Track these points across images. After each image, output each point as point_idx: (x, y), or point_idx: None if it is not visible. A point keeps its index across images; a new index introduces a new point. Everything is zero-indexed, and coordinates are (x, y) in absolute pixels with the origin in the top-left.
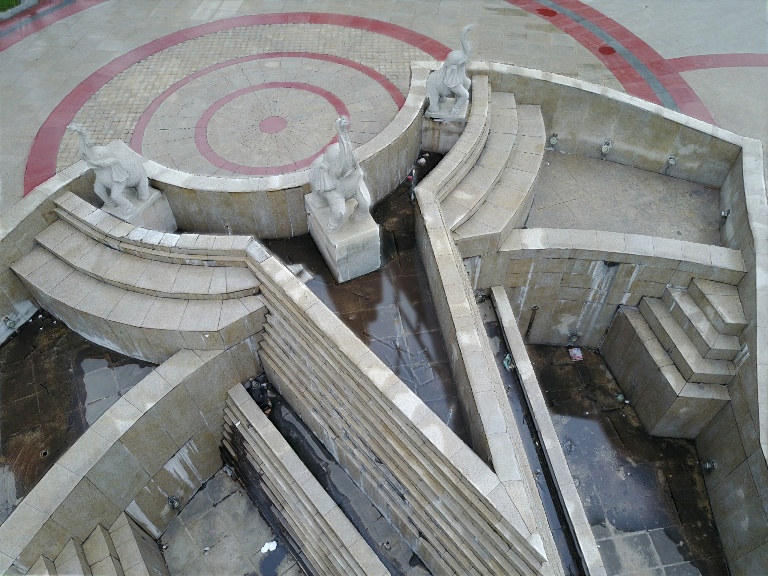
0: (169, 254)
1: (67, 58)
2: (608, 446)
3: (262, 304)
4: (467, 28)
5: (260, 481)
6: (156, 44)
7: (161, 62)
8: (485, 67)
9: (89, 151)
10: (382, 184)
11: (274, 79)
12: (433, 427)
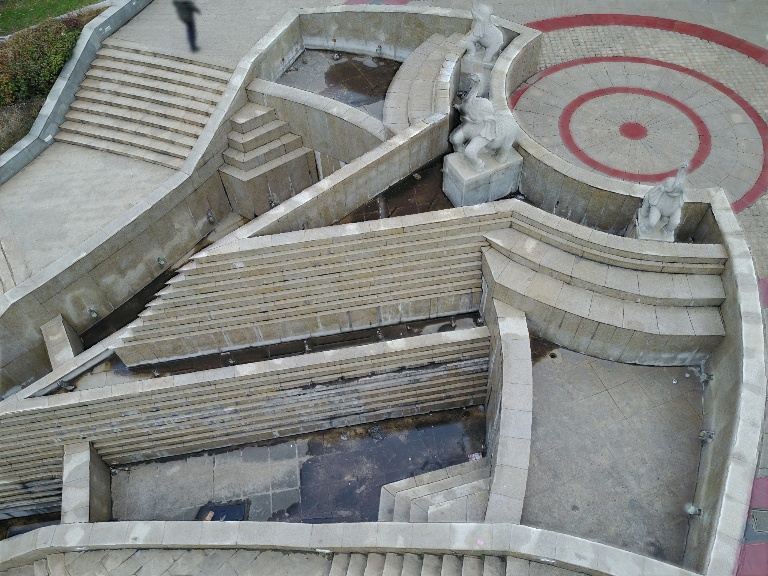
0: None
1: (691, 2)
2: (377, 471)
3: None
4: (683, 164)
5: None
6: (737, 42)
7: (707, 50)
8: (736, 250)
9: (476, 3)
10: (549, 199)
11: (710, 122)
12: (282, 209)
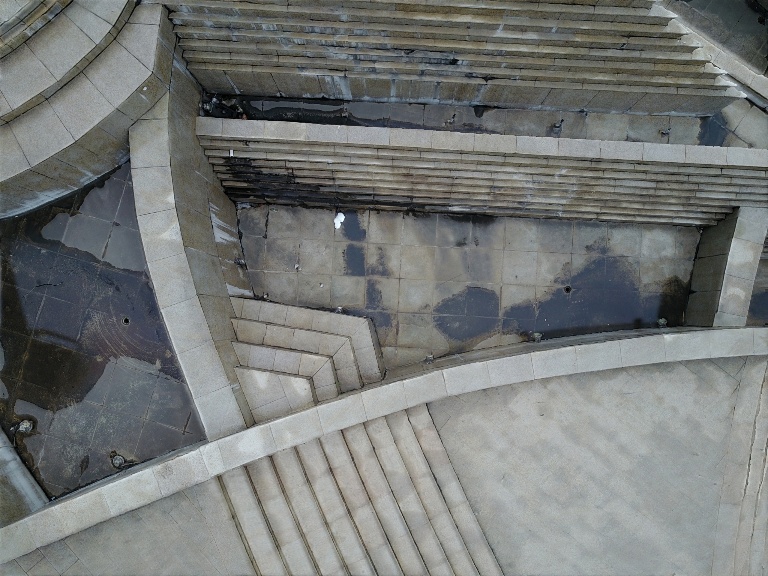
0: (0, 41)
1: None
2: None
3: (158, 5)
4: None
5: (293, 180)
6: None
7: None
8: None
9: None
10: None
11: None
12: None
